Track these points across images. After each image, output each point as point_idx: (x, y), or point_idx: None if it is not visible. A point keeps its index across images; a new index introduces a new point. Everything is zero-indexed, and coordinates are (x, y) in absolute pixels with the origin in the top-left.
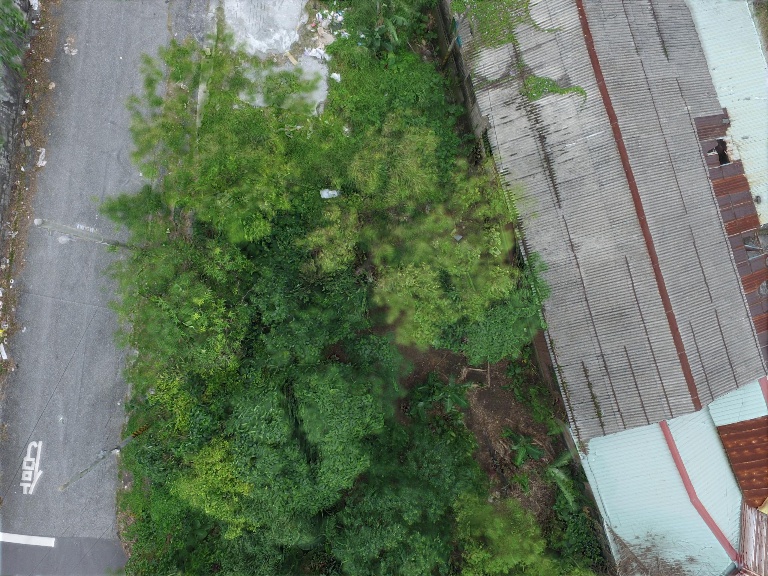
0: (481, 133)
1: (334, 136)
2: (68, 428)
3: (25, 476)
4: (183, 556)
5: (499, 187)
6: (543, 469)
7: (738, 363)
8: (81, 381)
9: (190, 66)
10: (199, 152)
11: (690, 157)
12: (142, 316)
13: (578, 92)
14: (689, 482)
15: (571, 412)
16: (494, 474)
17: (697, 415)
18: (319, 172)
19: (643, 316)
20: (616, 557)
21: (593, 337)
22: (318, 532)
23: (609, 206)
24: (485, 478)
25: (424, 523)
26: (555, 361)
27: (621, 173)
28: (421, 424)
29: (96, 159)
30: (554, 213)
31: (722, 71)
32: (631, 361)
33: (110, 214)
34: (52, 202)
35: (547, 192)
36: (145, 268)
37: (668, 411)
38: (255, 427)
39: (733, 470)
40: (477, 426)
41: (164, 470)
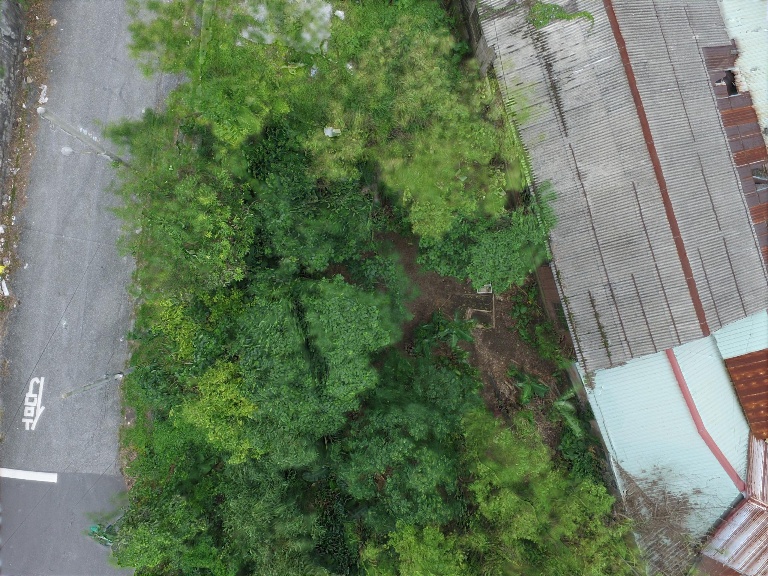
0: (486, 70)
1: (338, 72)
2: (70, 364)
3: (27, 412)
4: (187, 487)
5: (504, 123)
6: (548, 410)
7: (746, 292)
8: (83, 317)
9: (193, 3)
10: (202, 89)
11: (698, 86)
12: (145, 253)
13: (585, 17)
14: (697, 413)
15: (578, 343)
16: (499, 415)
17: (704, 348)
18: (323, 109)
19: (651, 242)
20: (622, 492)
21: (600, 266)
22: (323, 462)
23: (616, 132)
24: (490, 417)
25: (430, 441)
26: (561, 292)
27: (629, 98)
28: (426, 365)
29: (98, 96)
30: (561, 142)
31: (730, 3)
32: (638, 289)
33: (112, 151)
34: (54, 139)
35: (554, 121)
36: (149, 176)
37: (676, 338)
38: (260, 342)
39: (741, 403)
40: (482, 367)
41: (168, 395)
